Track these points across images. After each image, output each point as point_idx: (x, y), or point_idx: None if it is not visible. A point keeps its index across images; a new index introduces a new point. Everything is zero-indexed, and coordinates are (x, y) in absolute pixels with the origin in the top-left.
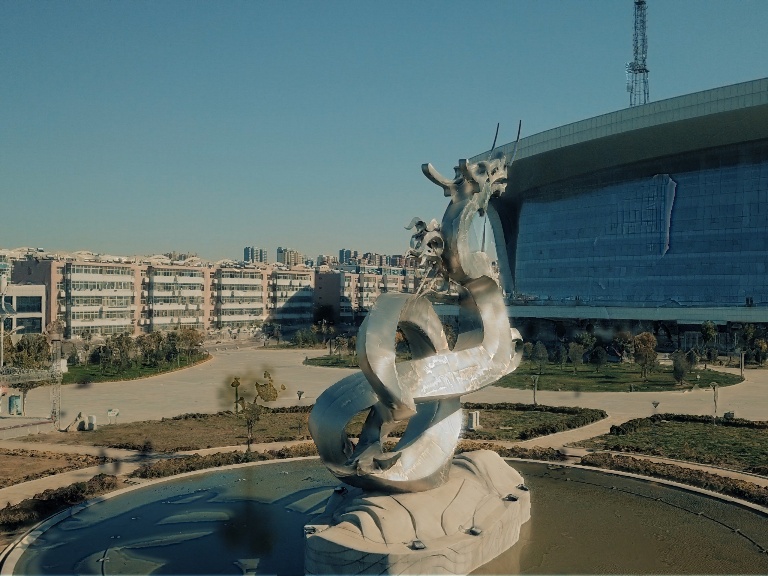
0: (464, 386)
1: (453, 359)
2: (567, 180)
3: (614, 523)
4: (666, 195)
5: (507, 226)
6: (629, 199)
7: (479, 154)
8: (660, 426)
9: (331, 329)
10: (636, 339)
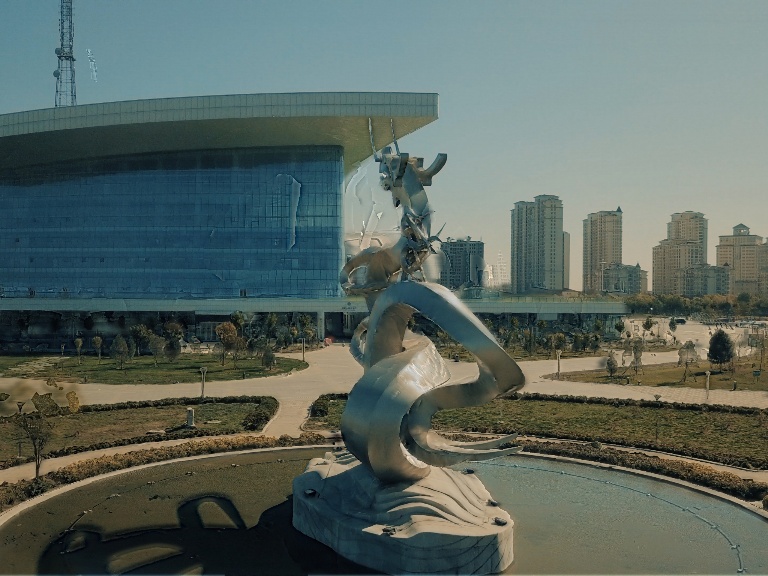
0: None
1: None
2: (51, 164)
3: None
4: (291, 194)
5: None
6: (252, 195)
7: None
8: (337, 405)
9: None
10: (218, 329)
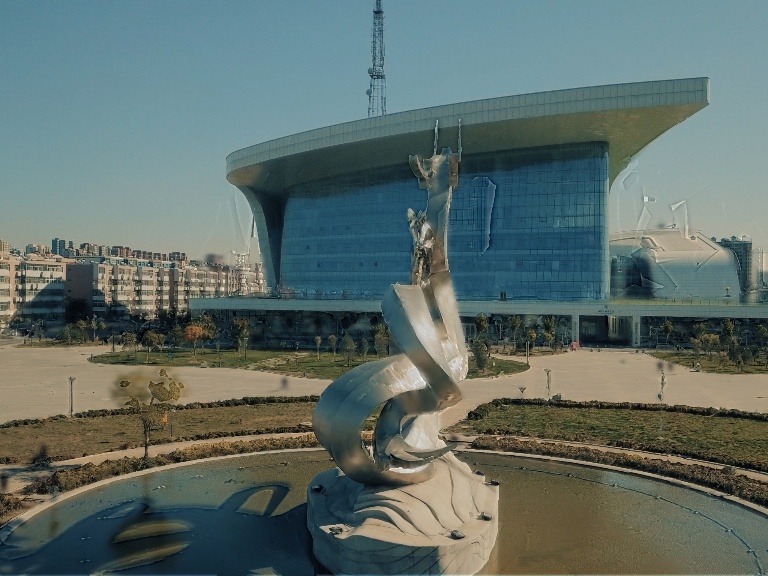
0: (457, 376)
1: None
2: (334, 177)
3: (542, 500)
4: (486, 196)
5: (271, 220)
6: None
7: (249, 146)
8: (504, 410)
9: (102, 324)
10: None
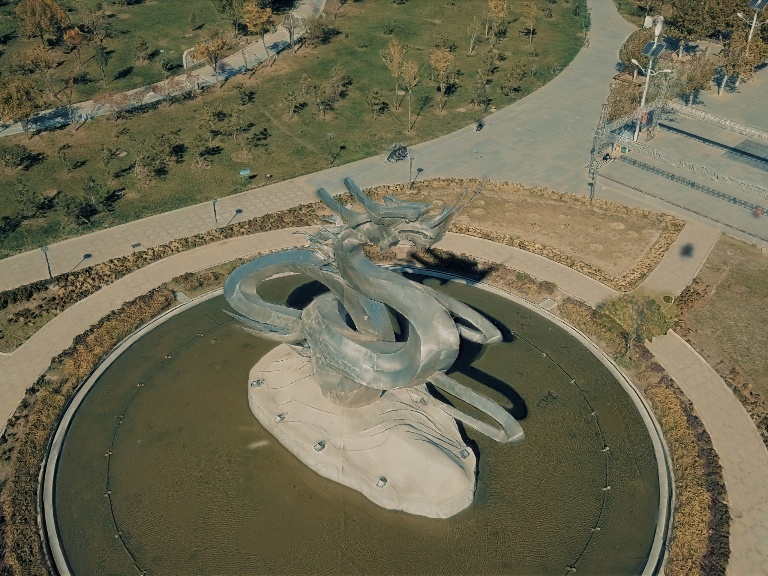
0: None
1: (329, 331)
2: None
3: None
4: None
5: None
6: None
7: None
8: None
9: None
10: None
